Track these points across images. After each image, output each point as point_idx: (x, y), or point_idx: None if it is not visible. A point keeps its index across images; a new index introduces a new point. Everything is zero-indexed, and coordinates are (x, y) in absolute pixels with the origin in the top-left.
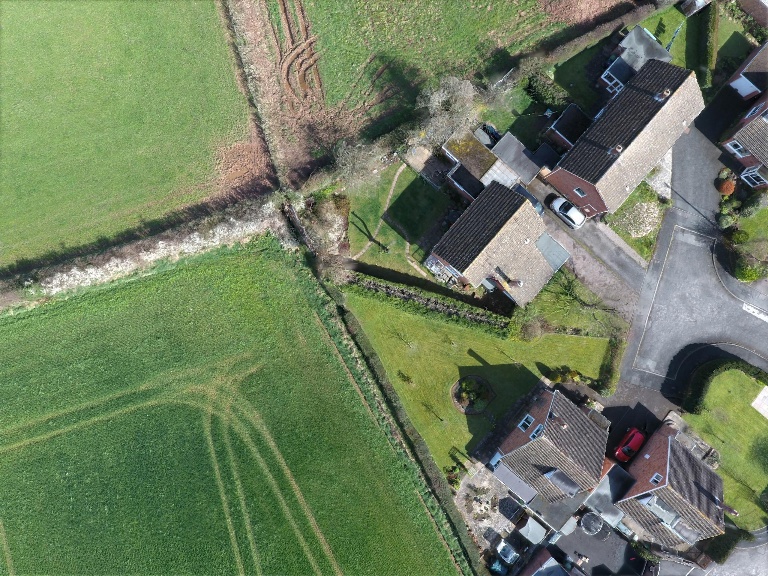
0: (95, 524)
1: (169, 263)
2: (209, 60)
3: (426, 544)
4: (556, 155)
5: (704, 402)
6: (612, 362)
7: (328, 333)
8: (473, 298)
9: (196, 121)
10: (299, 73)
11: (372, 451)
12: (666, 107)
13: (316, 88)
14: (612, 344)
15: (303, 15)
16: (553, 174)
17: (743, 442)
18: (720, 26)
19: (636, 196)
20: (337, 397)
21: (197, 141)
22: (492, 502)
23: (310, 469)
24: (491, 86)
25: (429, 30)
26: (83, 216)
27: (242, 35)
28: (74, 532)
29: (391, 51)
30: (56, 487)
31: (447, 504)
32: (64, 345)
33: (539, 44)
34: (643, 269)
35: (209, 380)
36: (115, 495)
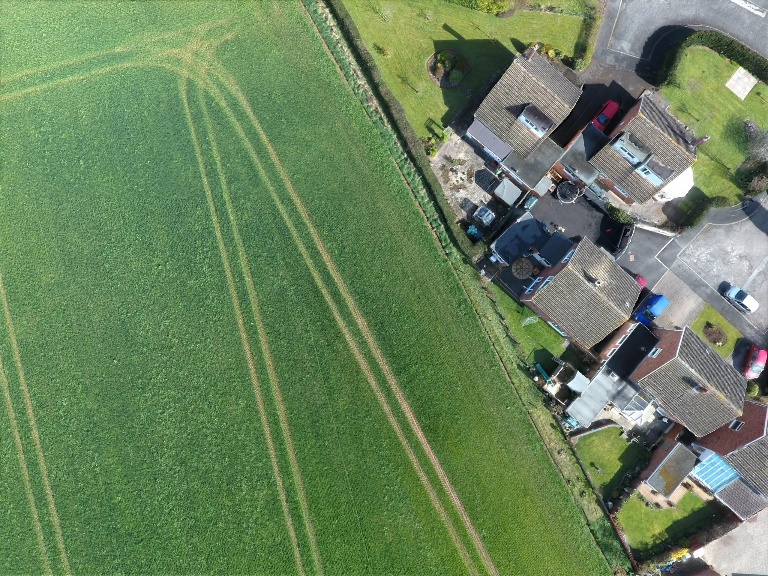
0: (70, 178)
1: None
2: None
3: (402, 211)
4: None
5: (678, 81)
6: None
7: (303, 4)
8: None
9: None
10: None
11: (348, 119)
12: None
13: None
14: (586, 23)
15: None
16: None
17: (718, 121)
18: None
19: None
20: (312, 66)
21: None
22: (468, 173)
23: (286, 134)
24: None
25: None
26: None
27: None
28: (49, 184)
29: None
30: (31, 141)
31: (422, 162)
32: (38, 5)
33: None
34: None
35: (184, 43)
36: (90, 151)
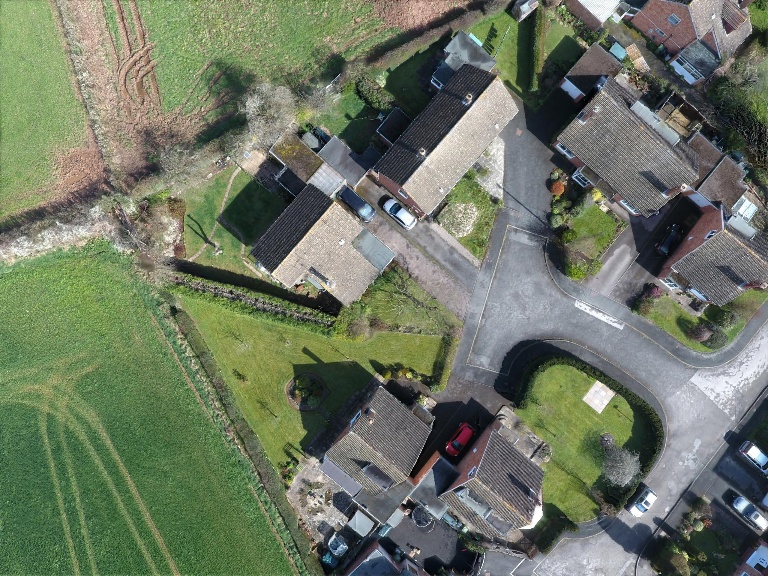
0: None
1: (5, 266)
2: (47, 68)
3: (260, 537)
4: None
5: (536, 397)
6: (445, 359)
7: (164, 333)
8: (307, 298)
9: (34, 128)
10: (136, 80)
11: (207, 447)
12: (472, 111)
13: (153, 94)
14: (445, 341)
15: (140, 23)
16: (379, 176)
17: (574, 436)
18: (551, 30)
19: (468, 197)
20: (172, 395)
21: (35, 147)
22: (326, 496)
23: (145, 466)
24: (317, 91)
25: (265, 37)
26: None
27: (75, 44)
28: None
29: (227, 58)
30: None
31: (276, 498)
32: None
33: (373, 49)
34: (476, 268)
35: (45, 380)
36: None
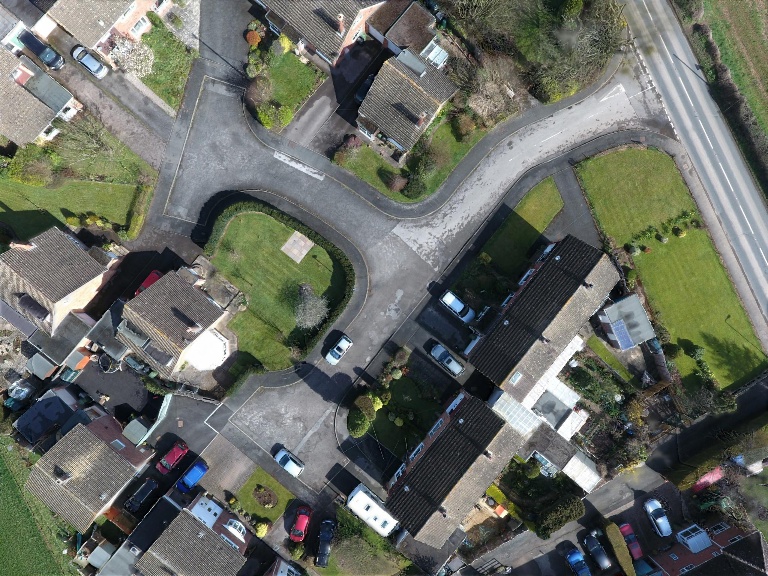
0: None
1: None
2: None
3: None
4: None
5: (233, 246)
6: (139, 208)
7: None
8: None
9: None
10: None
11: None
12: None
13: None
14: (140, 191)
15: None
16: None
17: (272, 285)
18: None
19: (163, 47)
20: None
21: None
22: (14, 344)
23: None
24: None
25: None
26: None
27: None
28: None
29: None
30: None
31: None
32: None
33: None
34: (171, 118)
35: None
36: None
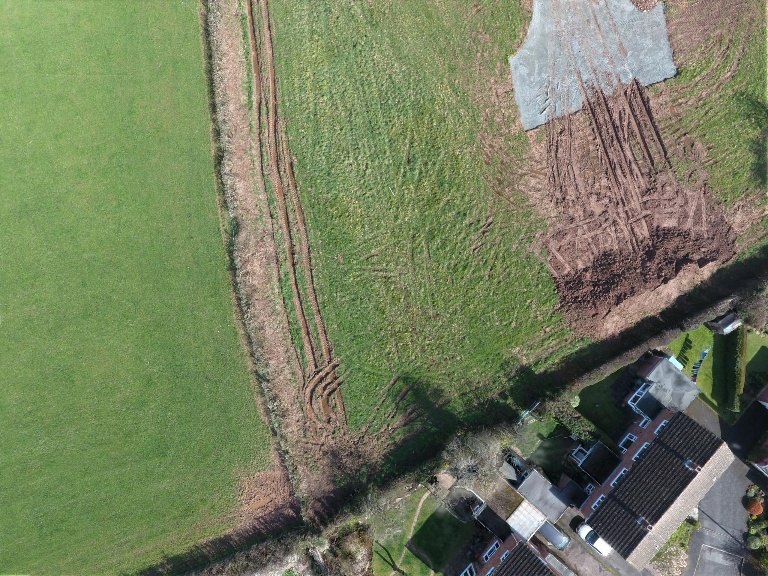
0: None
1: None
2: (232, 389)
3: None
4: (583, 493)
5: None
6: None
7: None
8: None
9: (219, 452)
10: (322, 398)
11: None
12: (697, 477)
13: (339, 413)
14: None
15: (326, 338)
16: None
17: None
18: (747, 341)
19: None
20: None
21: (220, 472)
22: None
23: None
24: (517, 424)
25: (453, 349)
26: (106, 554)
27: (266, 370)
28: None
29: (415, 372)
30: None
31: None
32: None
33: (564, 362)
34: None
35: None
36: None
